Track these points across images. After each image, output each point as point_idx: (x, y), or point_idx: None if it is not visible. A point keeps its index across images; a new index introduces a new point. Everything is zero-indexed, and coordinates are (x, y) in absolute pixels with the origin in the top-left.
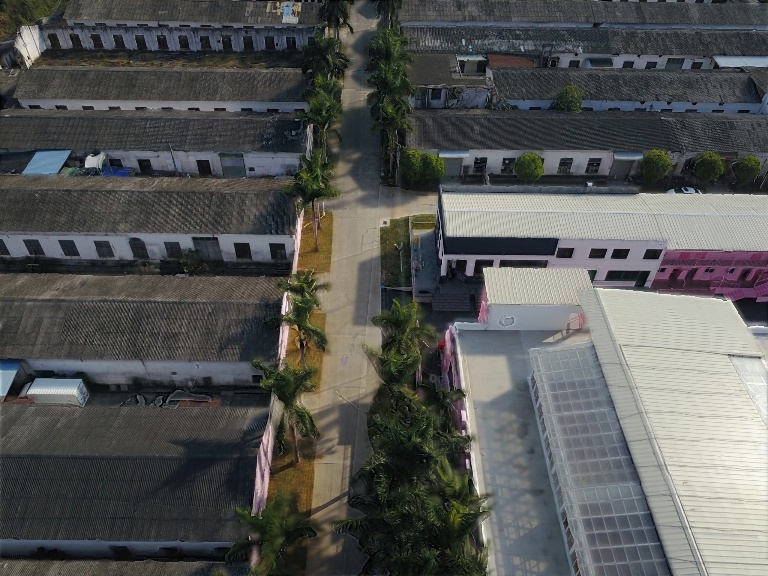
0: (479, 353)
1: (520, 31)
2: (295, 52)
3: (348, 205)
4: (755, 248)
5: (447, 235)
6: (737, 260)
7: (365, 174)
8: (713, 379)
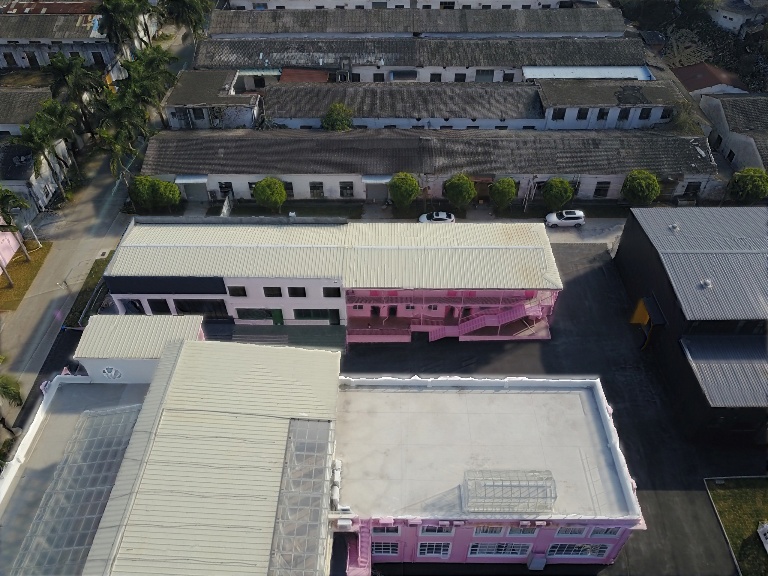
0: (67, 411)
1: (323, 43)
2: (103, 68)
3: (73, 235)
4: (438, 285)
5: (107, 274)
6: (432, 297)
7: (109, 200)
8: (251, 449)
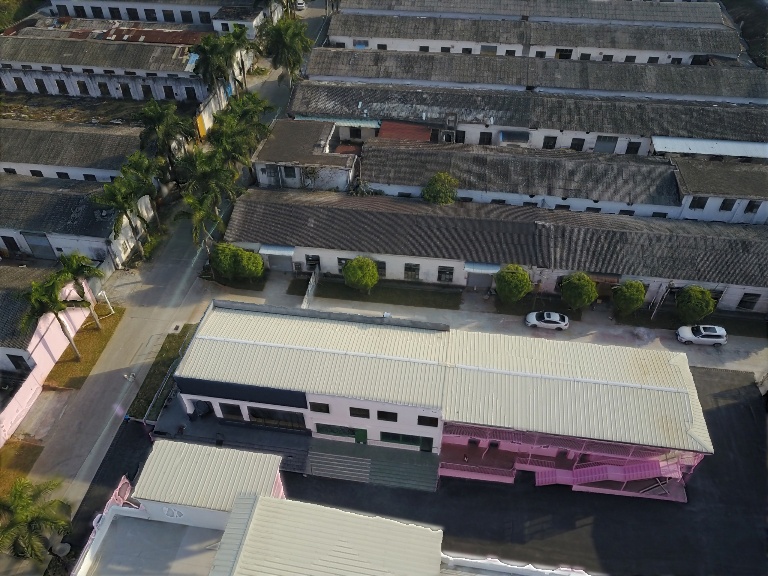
0: (119, 555)
1: (428, 95)
2: (195, 103)
3: (148, 301)
4: (557, 430)
5: (178, 373)
6: (546, 437)
7: (188, 262)
8: None
